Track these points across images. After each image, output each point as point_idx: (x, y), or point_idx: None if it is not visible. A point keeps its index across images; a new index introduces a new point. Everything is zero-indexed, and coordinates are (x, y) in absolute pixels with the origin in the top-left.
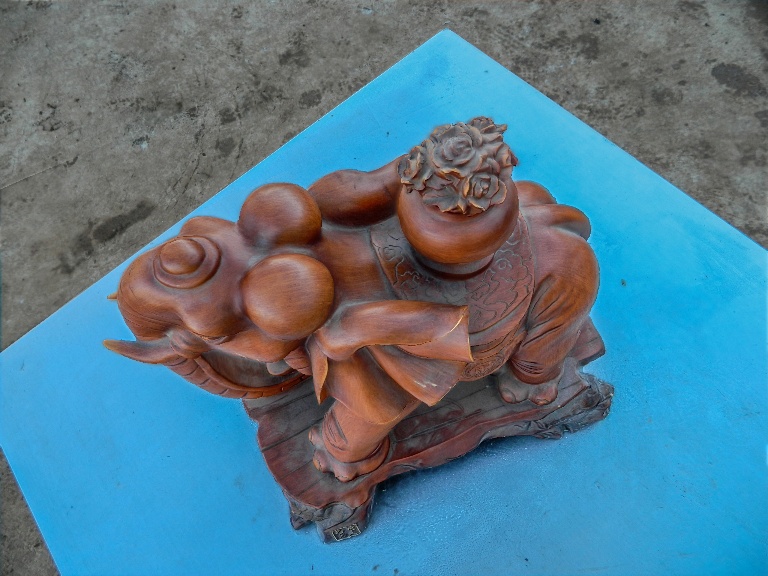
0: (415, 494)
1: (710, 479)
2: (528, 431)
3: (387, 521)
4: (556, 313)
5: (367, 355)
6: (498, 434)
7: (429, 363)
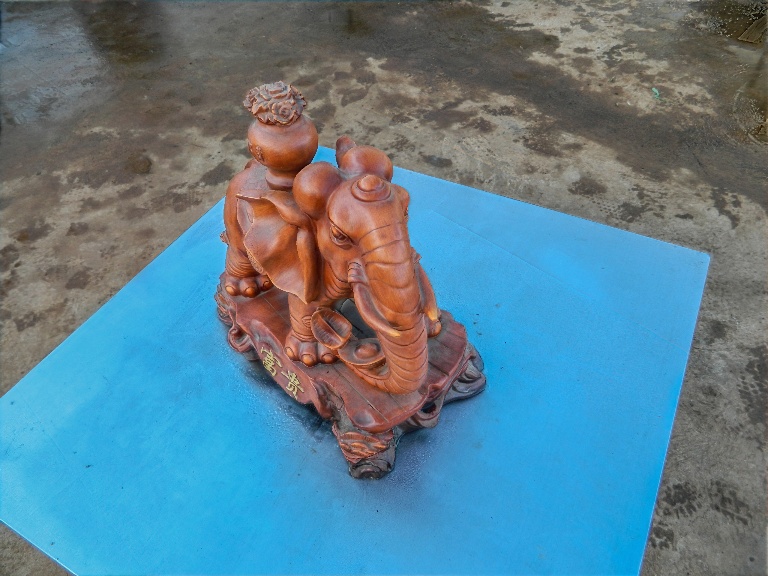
0: None
1: None
2: None
3: None
4: None
5: None
6: None
7: None
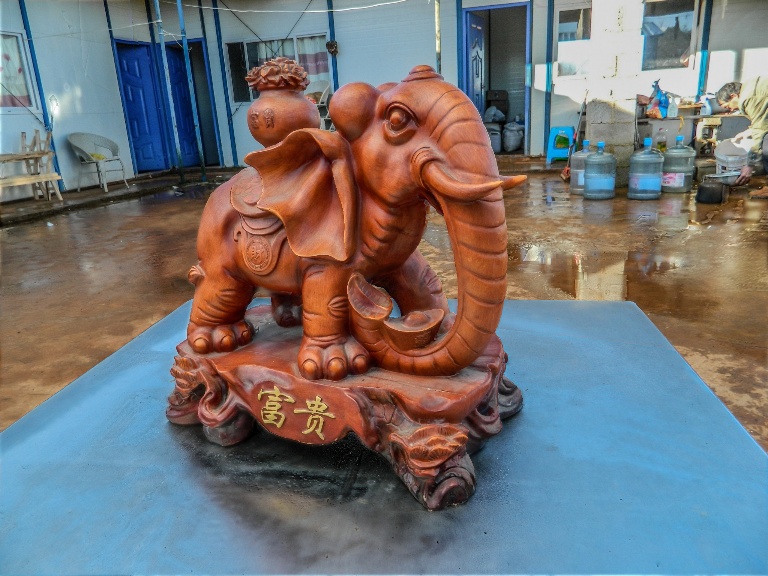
0: None
1: None
2: None
3: None
4: None
5: None
6: None
7: None
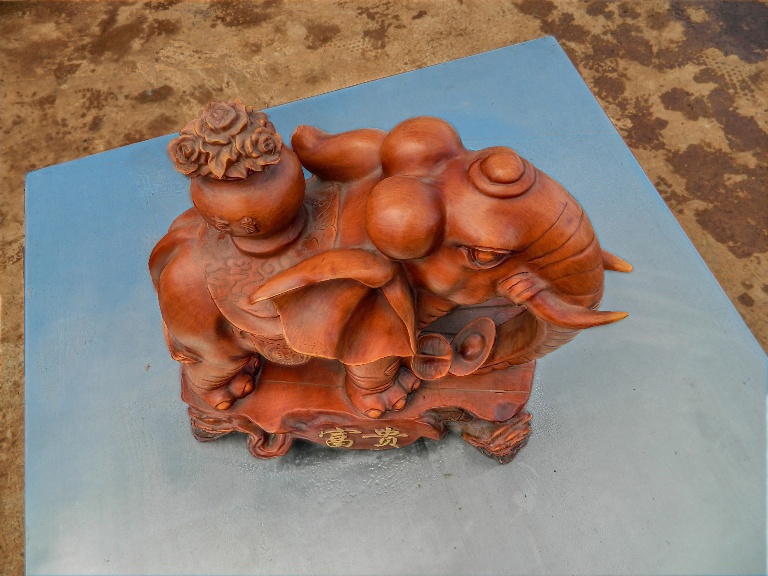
0: None
1: None
2: None
3: None
4: None
5: None
6: None
7: None
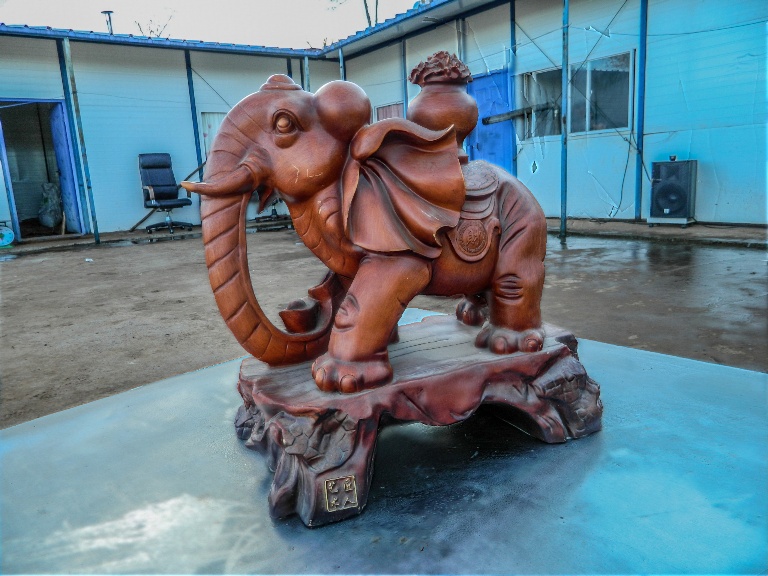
0: (419, 487)
1: (727, 453)
2: (528, 403)
3: (388, 506)
4: (519, 215)
5: (385, 195)
6: (498, 394)
7: (431, 206)
